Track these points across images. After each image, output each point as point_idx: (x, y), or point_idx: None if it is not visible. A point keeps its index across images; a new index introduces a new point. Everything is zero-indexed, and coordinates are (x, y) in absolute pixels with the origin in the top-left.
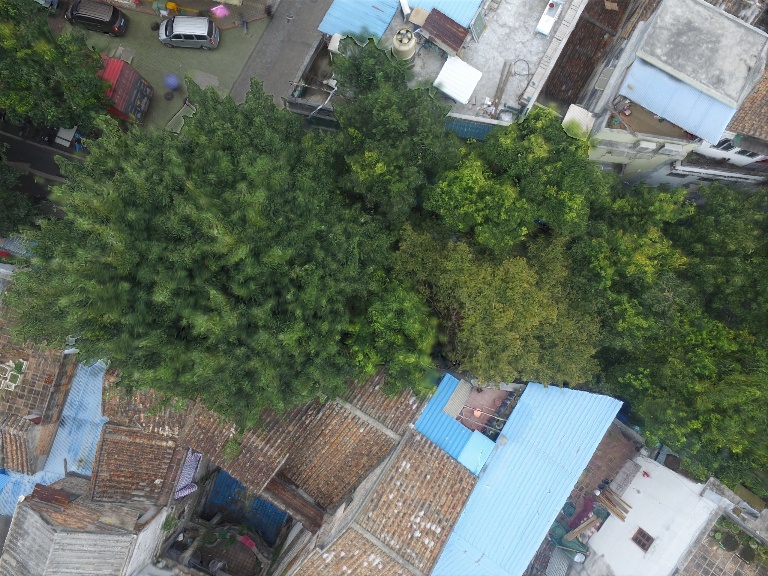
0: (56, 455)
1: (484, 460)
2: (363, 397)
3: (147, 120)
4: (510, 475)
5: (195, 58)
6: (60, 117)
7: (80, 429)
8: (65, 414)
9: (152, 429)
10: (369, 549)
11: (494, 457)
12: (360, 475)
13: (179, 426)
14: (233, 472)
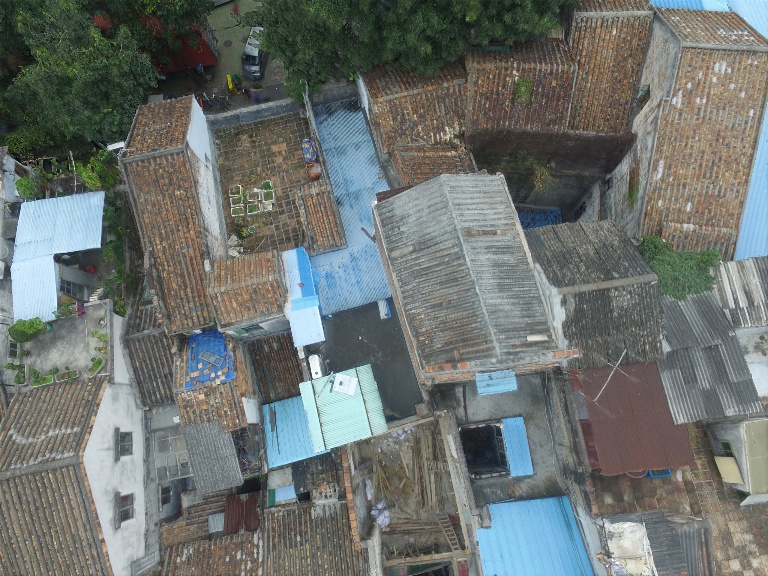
0: (351, 230)
1: (725, 3)
2: (597, 8)
3: (220, 67)
4: (752, 5)
5: (234, 9)
6: (182, 15)
7: (359, 199)
8: (337, 195)
9: (434, 139)
10: (710, 61)
11: (729, 1)
12: (633, 83)
13: (458, 119)
14: (532, 125)
